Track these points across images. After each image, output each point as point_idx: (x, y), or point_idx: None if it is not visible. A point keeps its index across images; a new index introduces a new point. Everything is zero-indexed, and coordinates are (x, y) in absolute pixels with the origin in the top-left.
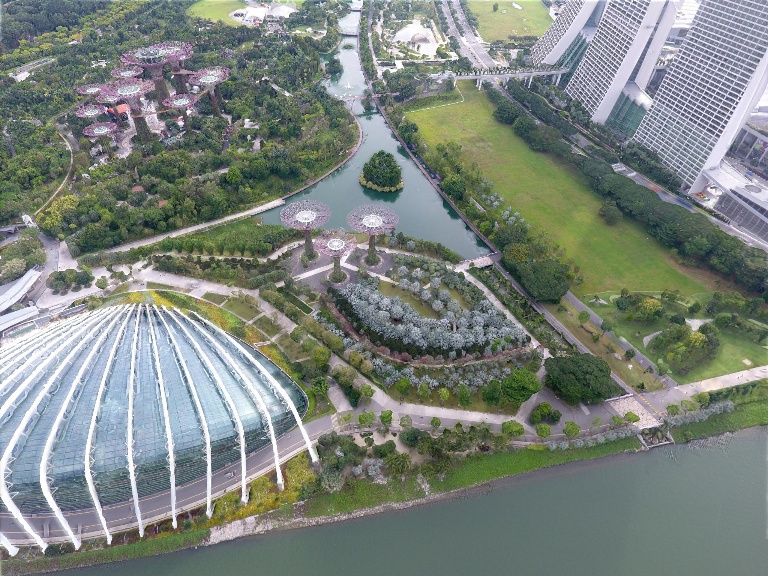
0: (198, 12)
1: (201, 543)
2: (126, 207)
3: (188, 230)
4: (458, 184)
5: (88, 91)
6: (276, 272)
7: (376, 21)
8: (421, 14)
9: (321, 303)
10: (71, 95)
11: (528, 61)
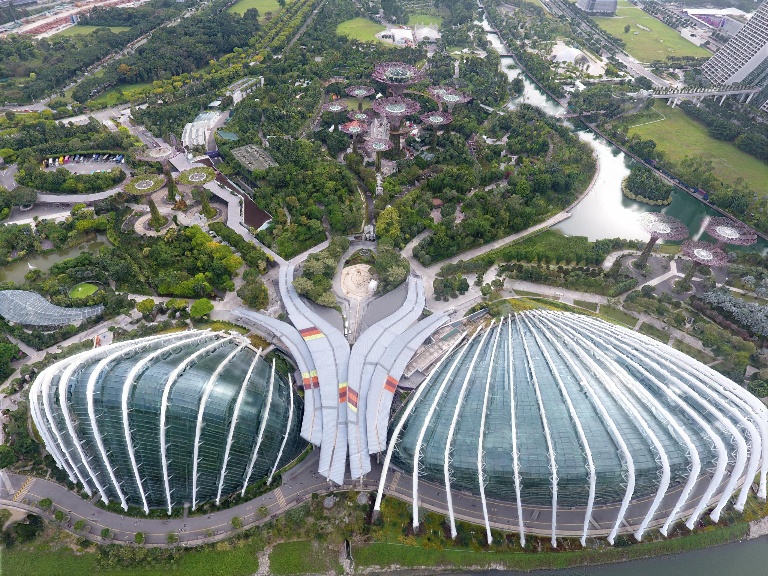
0: (354, 34)
1: (743, 537)
2: (455, 218)
3: (505, 241)
4: (740, 198)
5: (333, 109)
6: (632, 281)
7: (525, 42)
8: (559, 35)
9: (689, 310)
10: (305, 113)
11: (706, 80)
